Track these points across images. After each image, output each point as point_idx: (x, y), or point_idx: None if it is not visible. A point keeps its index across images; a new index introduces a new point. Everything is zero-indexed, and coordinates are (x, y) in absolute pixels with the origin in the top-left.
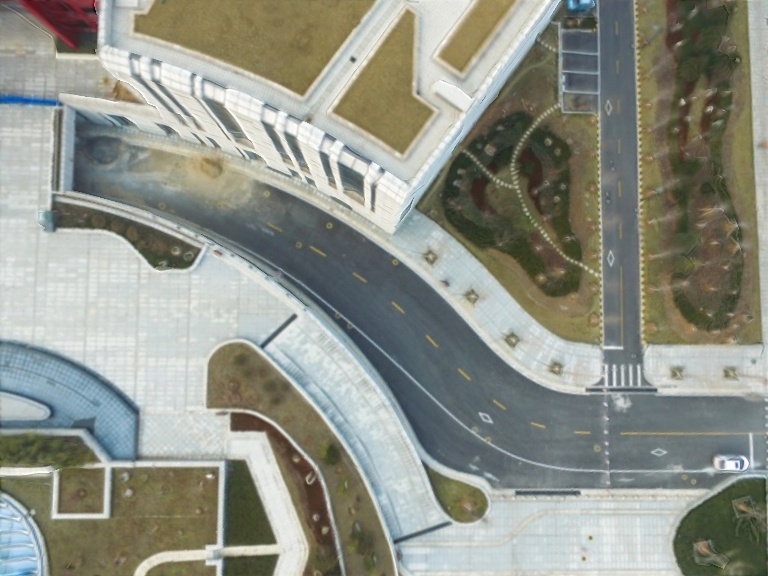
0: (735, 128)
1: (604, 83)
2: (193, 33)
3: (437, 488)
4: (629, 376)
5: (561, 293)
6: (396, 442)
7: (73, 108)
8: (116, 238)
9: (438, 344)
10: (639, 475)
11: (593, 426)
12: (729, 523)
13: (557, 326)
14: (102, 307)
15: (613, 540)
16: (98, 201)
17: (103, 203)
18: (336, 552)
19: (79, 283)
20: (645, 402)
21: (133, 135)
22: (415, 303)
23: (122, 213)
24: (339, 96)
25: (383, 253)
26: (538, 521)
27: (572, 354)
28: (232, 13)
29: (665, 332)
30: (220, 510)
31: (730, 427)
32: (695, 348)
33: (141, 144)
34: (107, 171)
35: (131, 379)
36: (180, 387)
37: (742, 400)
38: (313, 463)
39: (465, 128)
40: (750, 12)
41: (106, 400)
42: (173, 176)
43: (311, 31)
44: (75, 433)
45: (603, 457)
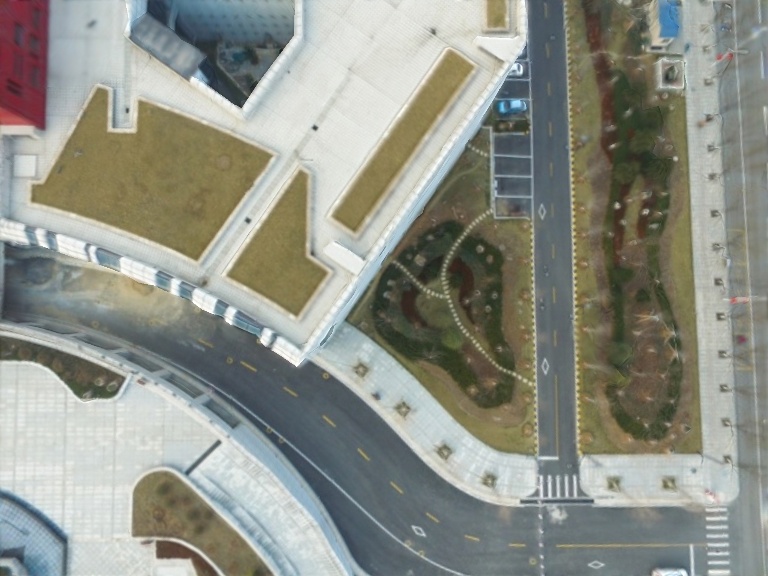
0: (673, 229)
1: (537, 186)
2: (89, 201)
3: None
4: (565, 487)
5: (494, 404)
6: (325, 561)
7: (1, 240)
8: (43, 369)
9: (370, 457)
10: None
11: (528, 538)
12: None
13: (490, 437)
14: (30, 437)
15: None
16: (24, 333)
17: (29, 335)
18: None
19: (8, 413)
20: (581, 513)
21: None
22: (346, 417)
23: (48, 344)
24: (233, 260)
25: (313, 367)
26: None
27: (506, 465)
28: (127, 180)
29: (601, 442)
30: None
31: (670, 538)
32: (632, 458)
33: (74, 263)
34: (42, 291)
35: (59, 508)
36: (107, 515)
37: (682, 510)
38: None
39: None
40: (688, 109)
41: (35, 529)
42: (106, 294)
43: (205, 195)
44: (4, 563)
45: (538, 570)
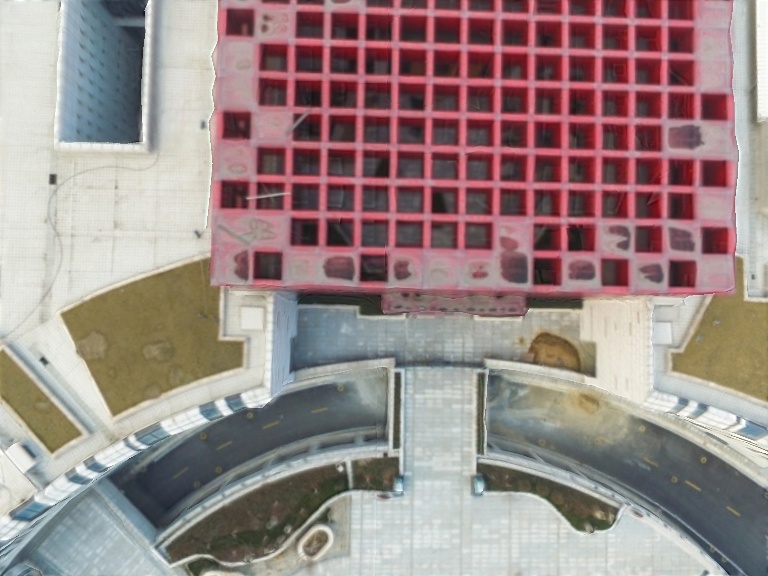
0: None
1: None
2: (728, 371)
3: None
4: None
5: None
6: None
7: None
8: (539, 500)
9: None
10: None
11: None
12: None
13: None
14: (524, 568)
15: None
16: (522, 465)
17: (526, 466)
18: None
19: (502, 544)
20: None
21: (513, 372)
22: None
23: (543, 474)
24: None
25: (755, 487)
26: None
27: None
28: (763, 349)
29: None
30: None
31: None
32: None
33: (521, 381)
34: (489, 408)
35: None
36: None
37: None
38: None
39: None
40: None
41: None
42: (552, 412)
43: None
44: None
45: None
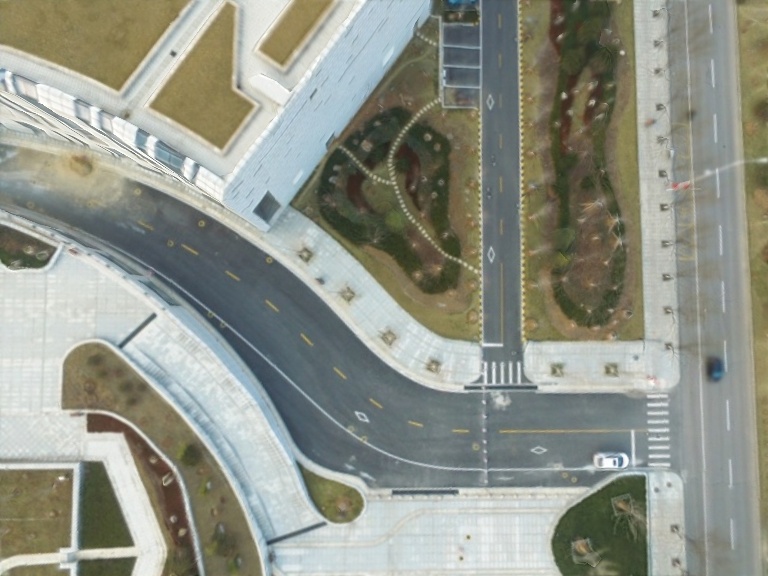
0: (619, 122)
1: (486, 77)
2: (5, 28)
3: (311, 488)
4: (509, 373)
5: (439, 290)
6: (265, 442)
7: None
8: None
9: (313, 342)
10: (519, 473)
11: (472, 424)
12: (607, 521)
13: (435, 323)
14: None
15: (491, 539)
16: None
17: None
18: (194, 554)
19: None
20: (525, 399)
21: (1, 133)
22: (289, 301)
23: None
24: (156, 91)
25: (257, 251)
26: (415, 521)
27: (450, 352)
28: (46, 7)
29: (545, 329)
30: (74, 512)
31: (611, 424)
32: (576, 345)
33: (9, 142)
34: None
35: None
36: (36, 388)
37: (624, 397)
38: (171, 464)
39: (320, 123)
40: (636, 4)
41: None
42: (42, 175)
43: (127, 25)
44: None
45: (481, 455)
